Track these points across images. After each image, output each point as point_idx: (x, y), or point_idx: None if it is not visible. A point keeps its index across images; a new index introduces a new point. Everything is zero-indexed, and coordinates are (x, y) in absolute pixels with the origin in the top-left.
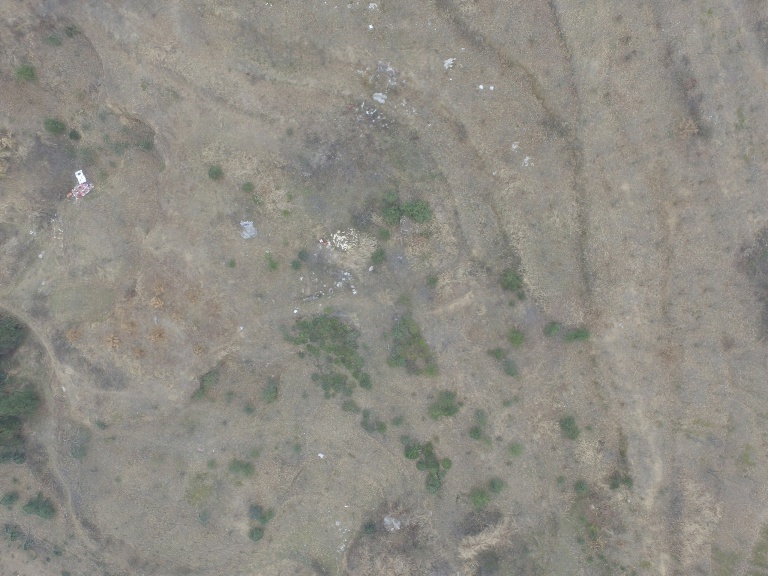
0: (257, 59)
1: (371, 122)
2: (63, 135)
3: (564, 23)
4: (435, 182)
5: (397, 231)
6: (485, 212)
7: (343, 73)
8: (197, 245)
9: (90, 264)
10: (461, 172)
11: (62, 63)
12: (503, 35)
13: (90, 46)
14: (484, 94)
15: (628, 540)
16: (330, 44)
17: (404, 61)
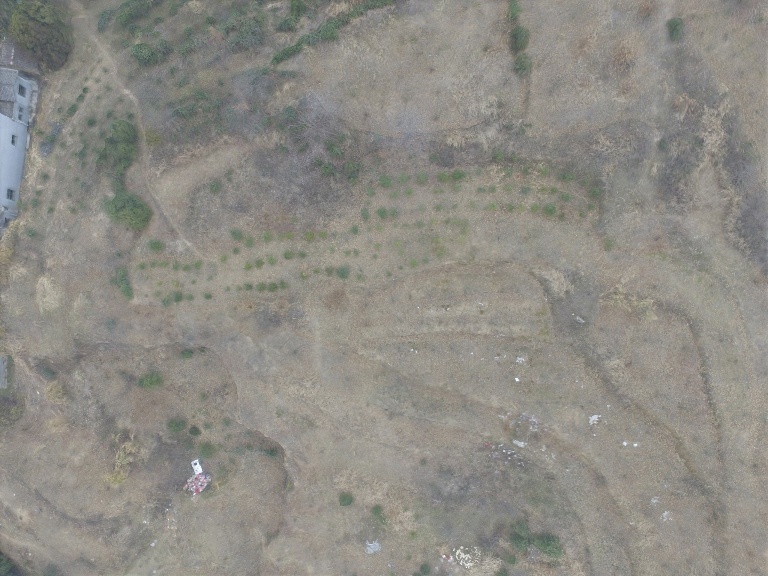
0: (397, 398)
1: (507, 459)
2: (183, 430)
3: (715, 395)
4: (567, 518)
5: (524, 558)
6: (617, 555)
7: (484, 416)
8: (320, 559)
9: (205, 560)
10: (596, 515)
11: (189, 369)
12: (652, 400)
13: (221, 361)
14: (627, 450)
15: None
16: (474, 393)
17: (549, 415)
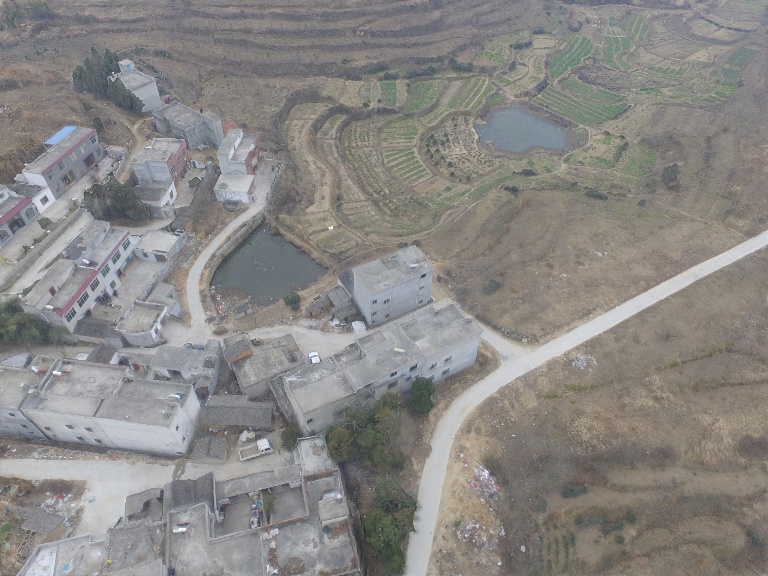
0: None
1: None
2: None
3: None
4: None
5: None
6: None
7: None
8: None
9: None
10: None
11: None
12: None
13: None
14: None
15: None
16: None
17: None
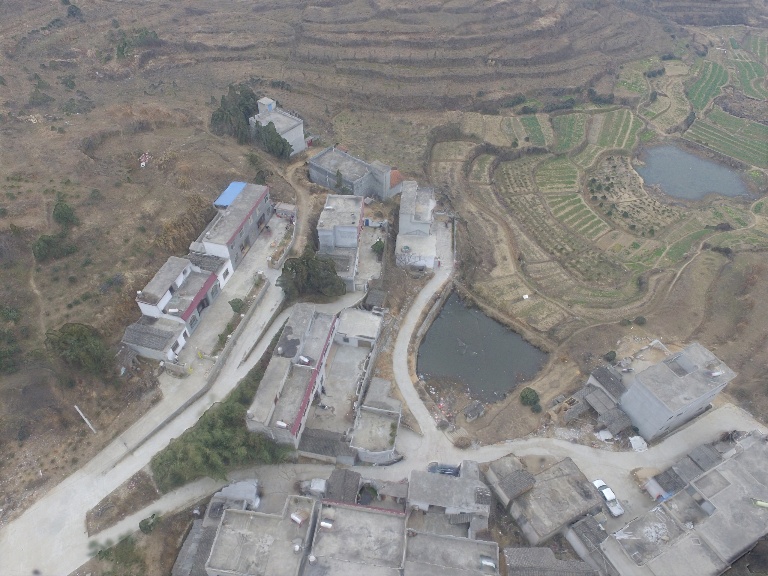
0: None
1: None
2: None
3: None
4: None
5: (4, 115)
6: None
7: None
8: None
9: None
10: None
11: None
12: None
13: None
14: None
15: (6, 42)
16: None
17: None
